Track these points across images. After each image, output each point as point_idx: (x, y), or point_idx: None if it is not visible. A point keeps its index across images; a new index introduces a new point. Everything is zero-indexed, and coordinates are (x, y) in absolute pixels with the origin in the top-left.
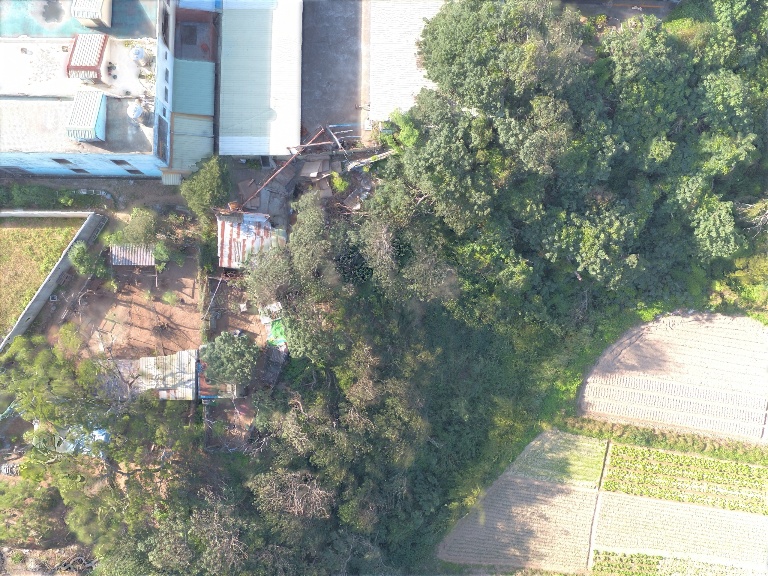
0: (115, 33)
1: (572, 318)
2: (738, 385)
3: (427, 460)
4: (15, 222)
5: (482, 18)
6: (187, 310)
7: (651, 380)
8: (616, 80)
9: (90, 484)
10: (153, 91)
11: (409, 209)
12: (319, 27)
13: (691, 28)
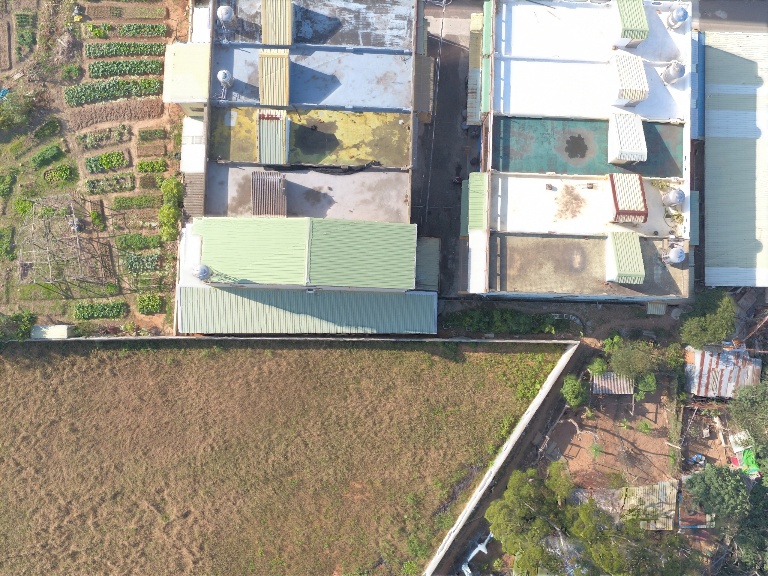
0: (639, 170)
1: None
2: None
3: None
4: (488, 347)
5: None
6: (650, 435)
7: None
8: None
9: None
10: (678, 230)
11: None
12: None
13: None
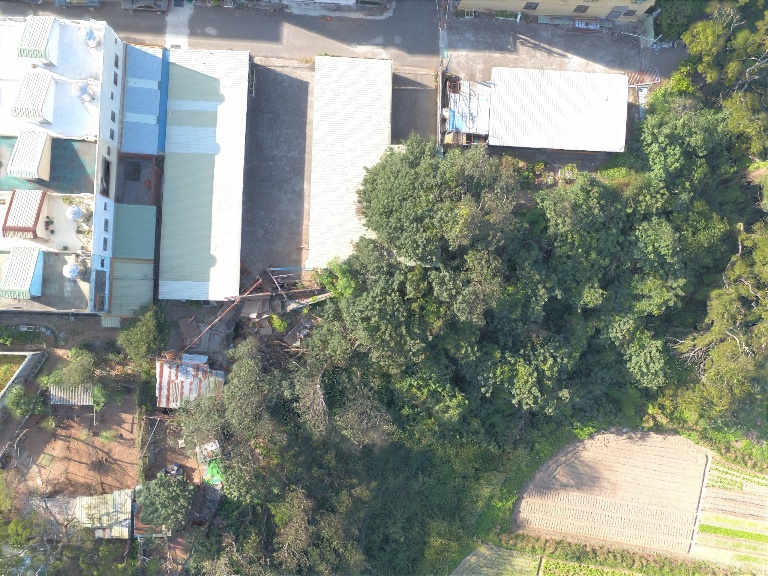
0: (53, 186)
1: (509, 437)
2: (668, 502)
3: None
4: None
5: (419, 176)
6: (126, 445)
7: (585, 496)
8: (550, 232)
9: None
10: (90, 246)
11: (346, 352)
12: (262, 166)
13: (626, 178)
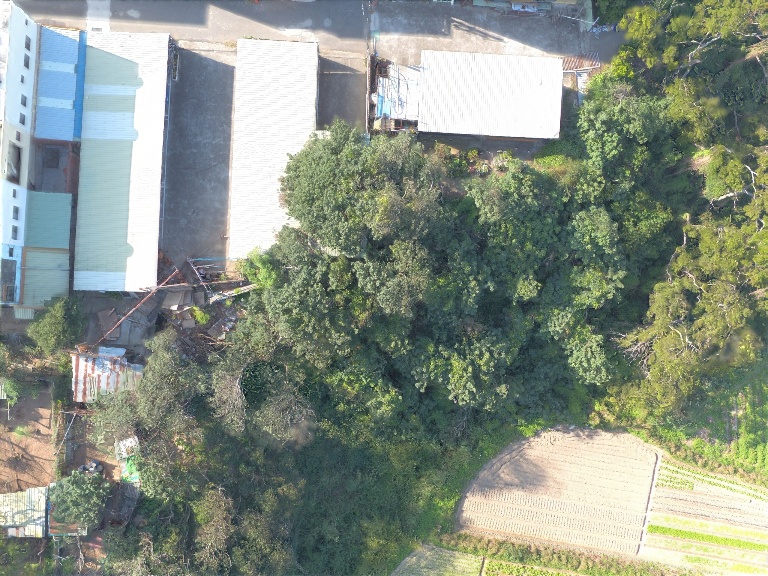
0: None
1: (451, 435)
2: (616, 502)
3: None
4: None
5: (341, 162)
6: (43, 441)
7: (530, 495)
8: (481, 222)
9: None
10: None
11: (270, 346)
12: (186, 153)
13: (562, 166)
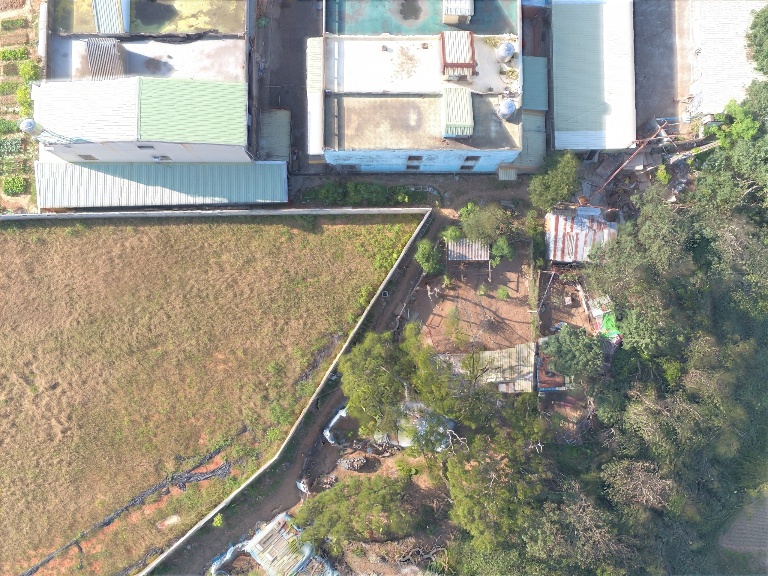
0: (473, 29)
1: None
2: None
3: (716, 448)
4: (345, 219)
5: None
6: (512, 304)
7: None
8: None
9: (424, 477)
10: (514, 87)
11: (736, 200)
12: None
13: None
